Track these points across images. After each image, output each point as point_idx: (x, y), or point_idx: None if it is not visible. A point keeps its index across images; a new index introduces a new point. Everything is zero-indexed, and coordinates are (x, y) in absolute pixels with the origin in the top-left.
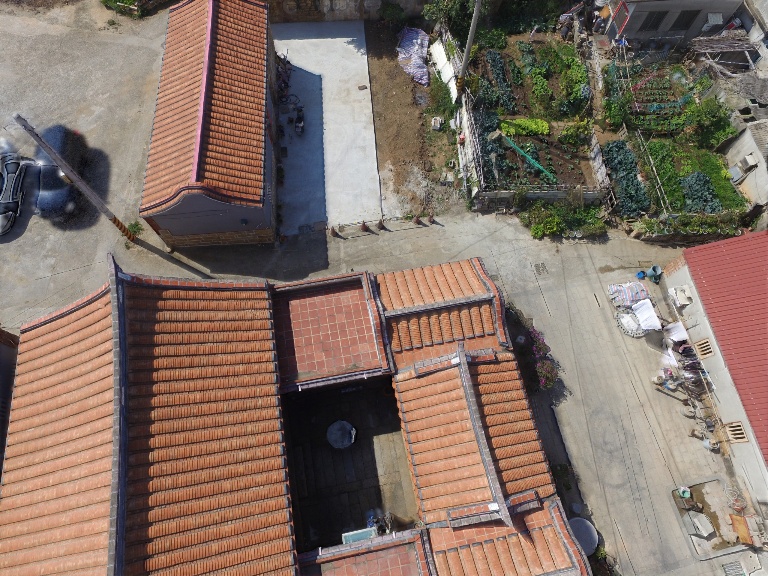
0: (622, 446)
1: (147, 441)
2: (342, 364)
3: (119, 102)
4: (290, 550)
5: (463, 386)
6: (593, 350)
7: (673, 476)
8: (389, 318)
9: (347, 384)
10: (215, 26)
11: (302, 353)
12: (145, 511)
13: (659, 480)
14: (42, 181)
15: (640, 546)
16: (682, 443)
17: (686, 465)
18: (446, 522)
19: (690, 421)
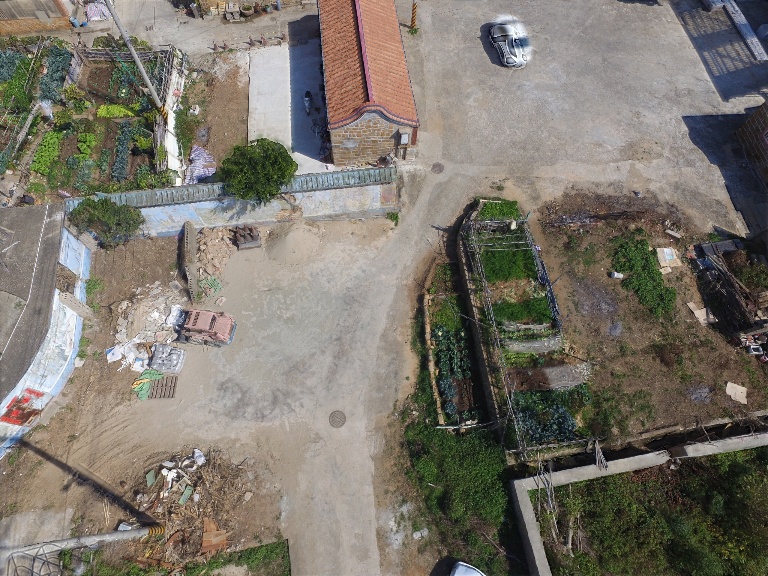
0: None
1: None
2: None
3: (457, 109)
4: None
5: None
6: None
7: None
8: None
9: None
10: (363, 74)
11: None
12: None
13: None
14: (486, 54)
15: None
16: None
17: None
18: None
19: None
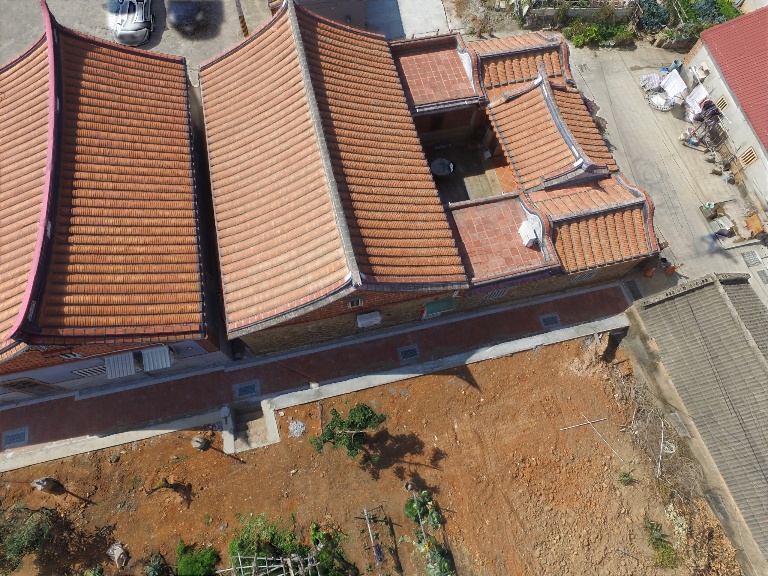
0: (659, 181)
1: (327, 106)
2: (447, 96)
3: None
4: (433, 188)
5: (545, 98)
6: (631, 120)
7: (700, 199)
8: (482, 59)
9: (440, 141)
10: None
11: (415, 89)
12: (336, 143)
13: (689, 201)
14: (167, 7)
15: (678, 241)
16: (705, 178)
17: (709, 192)
18: (540, 186)
19: (710, 164)
